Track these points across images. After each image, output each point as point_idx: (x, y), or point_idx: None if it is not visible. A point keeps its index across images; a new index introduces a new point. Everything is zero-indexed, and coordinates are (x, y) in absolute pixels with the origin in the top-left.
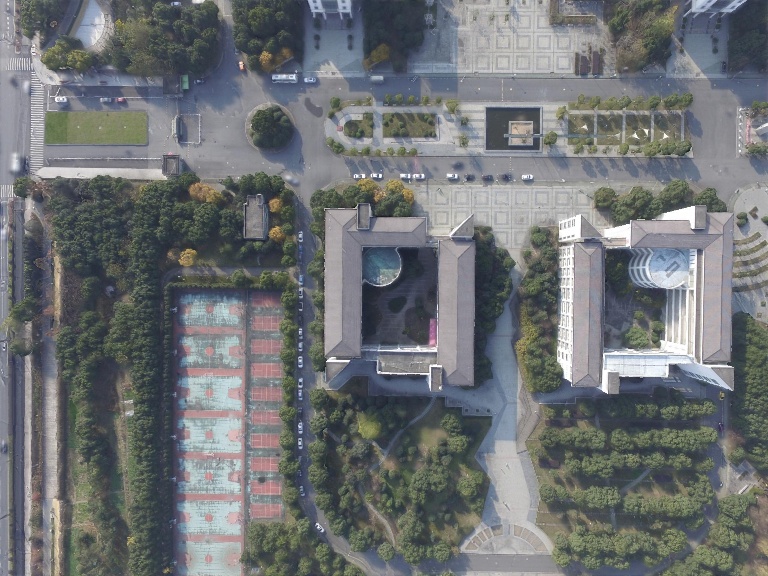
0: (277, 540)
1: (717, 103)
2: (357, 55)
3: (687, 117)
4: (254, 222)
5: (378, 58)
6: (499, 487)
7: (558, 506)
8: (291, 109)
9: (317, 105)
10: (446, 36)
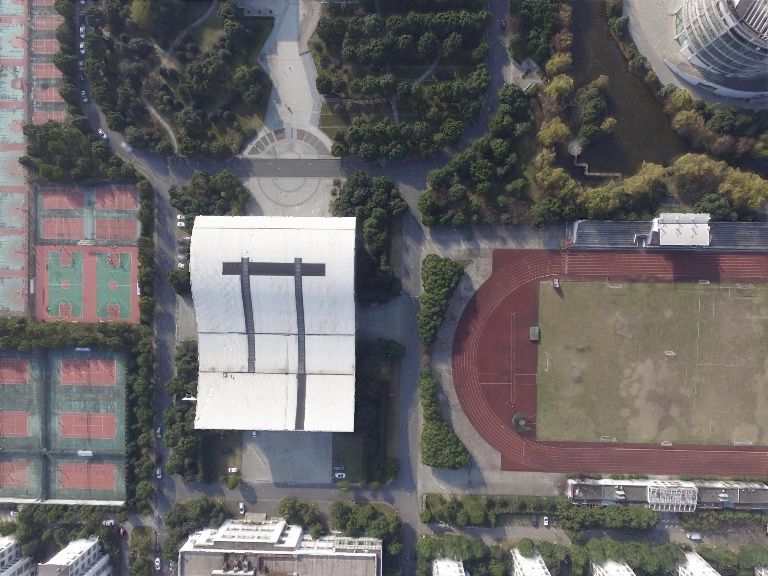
0: (50, 129)
1: None
2: None
3: None
4: None
5: None
6: (282, 90)
7: None
8: None
9: None
10: None
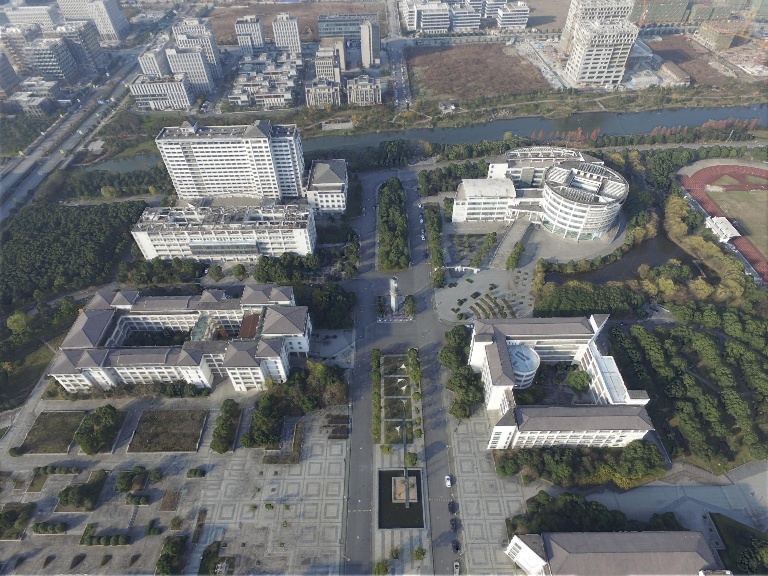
0: None
1: (375, 335)
2: None
3: (386, 353)
4: None
5: None
6: None
7: (763, 442)
8: None
9: None
10: None
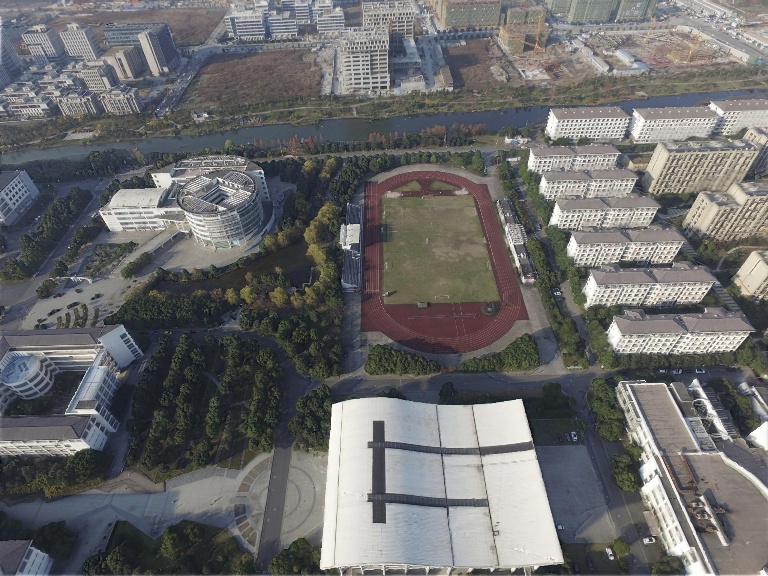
0: None
1: None
2: None
3: None
4: None
5: None
6: (194, 510)
7: None
8: None
9: None
10: None
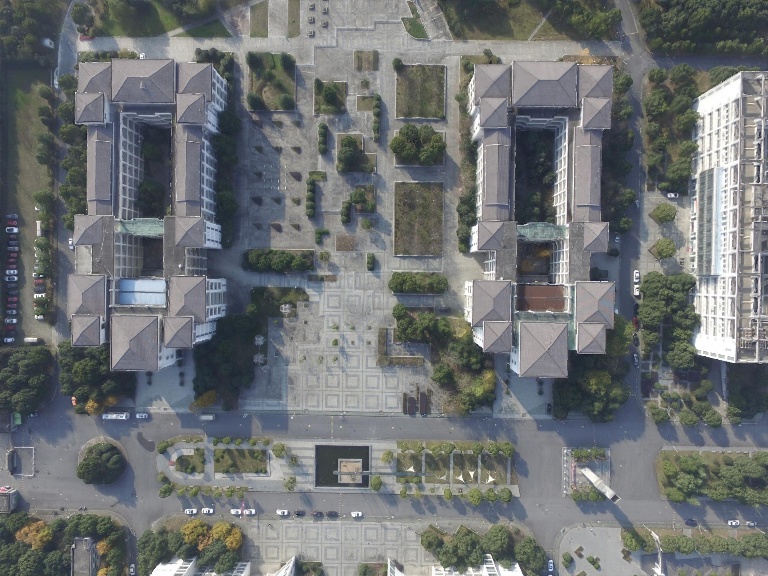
0: None
1: (543, 443)
2: (189, 391)
3: (513, 457)
4: (81, 565)
5: (204, 405)
6: None
7: None
8: (124, 443)
9: (149, 440)
10: (277, 373)
